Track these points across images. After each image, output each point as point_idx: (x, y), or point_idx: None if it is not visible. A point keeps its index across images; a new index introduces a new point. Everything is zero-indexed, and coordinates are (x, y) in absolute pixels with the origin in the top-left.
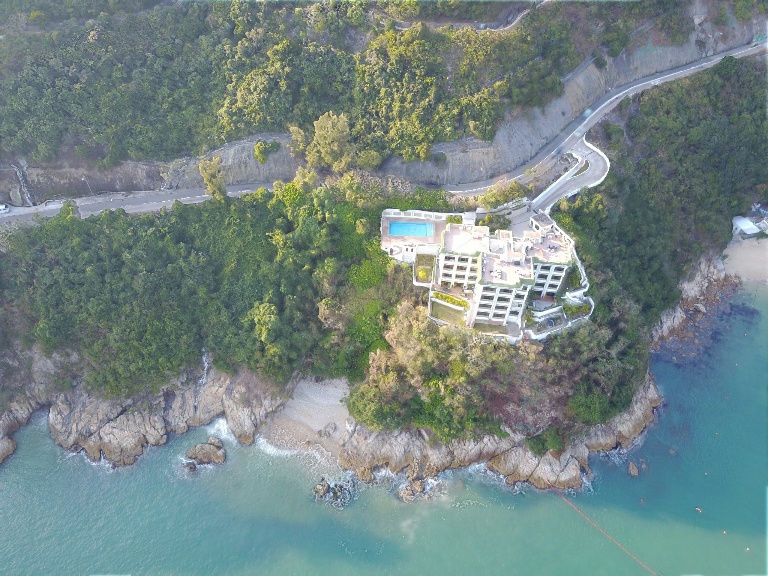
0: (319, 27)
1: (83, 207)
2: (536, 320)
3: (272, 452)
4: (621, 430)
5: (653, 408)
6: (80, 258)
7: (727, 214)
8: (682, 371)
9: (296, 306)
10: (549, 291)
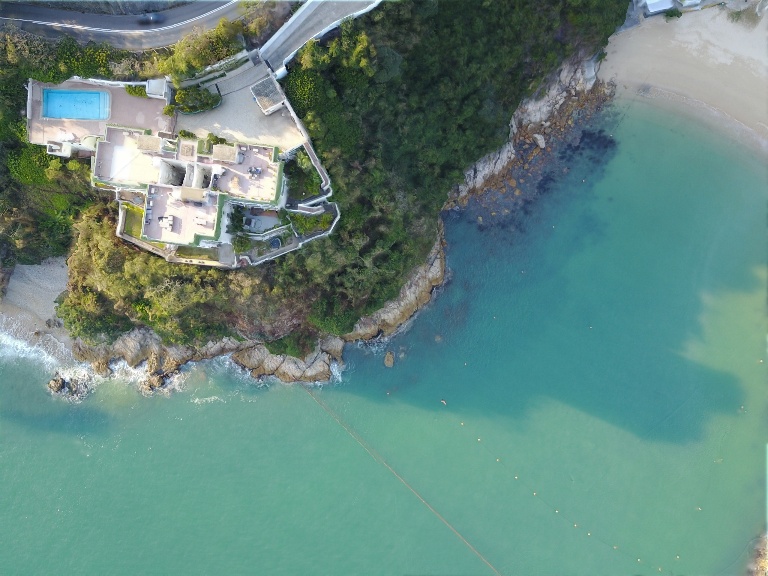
0: None
1: None
2: (259, 239)
3: (1, 342)
4: (385, 318)
5: (433, 287)
6: None
7: None
8: (484, 235)
9: None
10: (270, 209)
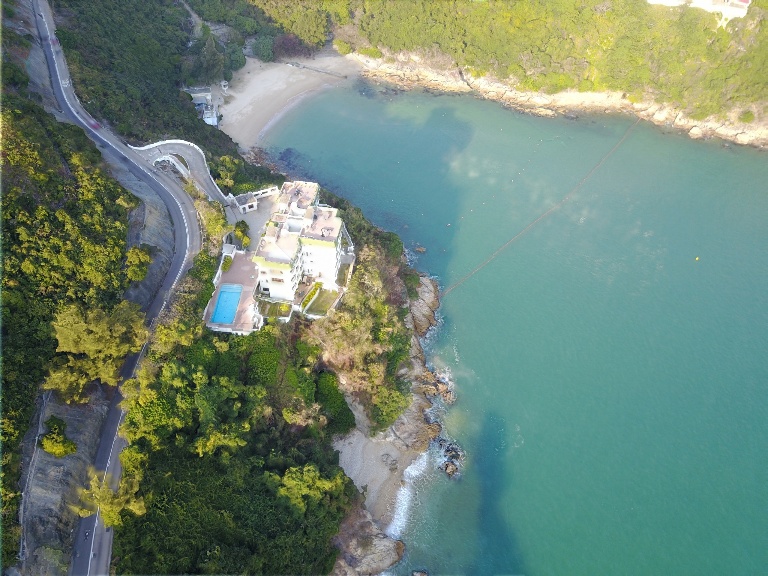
0: None
1: None
2: None
3: (412, 521)
4: None
5: None
6: None
7: None
8: None
9: None
10: None
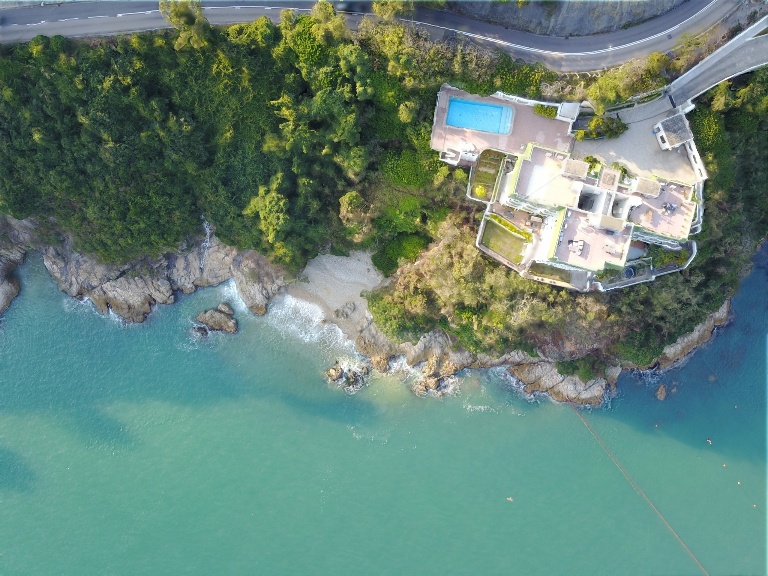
0: None
1: (4, 14)
2: None
3: (286, 325)
4: (666, 352)
5: (715, 327)
6: (21, 117)
7: None
8: None
9: (313, 190)
10: (643, 241)
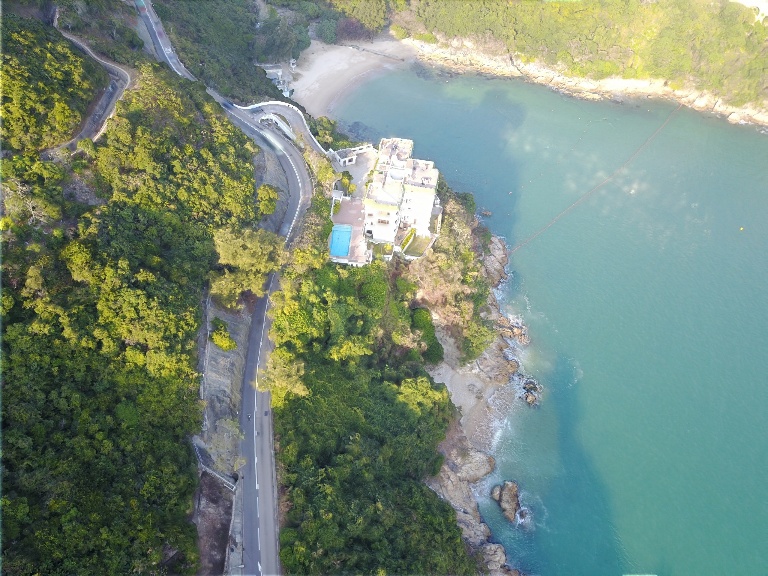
0: (57, 210)
1: None
2: None
3: (499, 440)
4: None
5: None
6: None
7: None
8: None
9: None
10: None
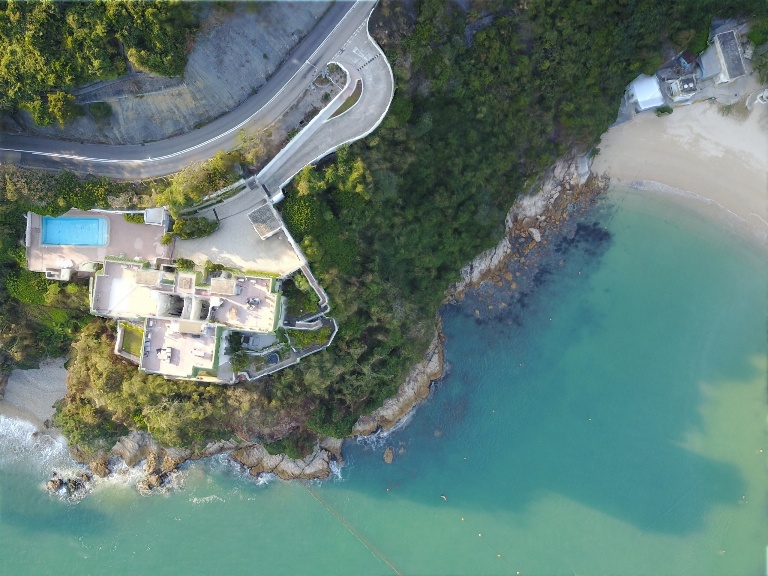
0: None
1: None
2: (257, 354)
3: None
4: (384, 415)
5: (431, 381)
6: None
7: (616, 87)
8: (482, 329)
9: None
10: None
